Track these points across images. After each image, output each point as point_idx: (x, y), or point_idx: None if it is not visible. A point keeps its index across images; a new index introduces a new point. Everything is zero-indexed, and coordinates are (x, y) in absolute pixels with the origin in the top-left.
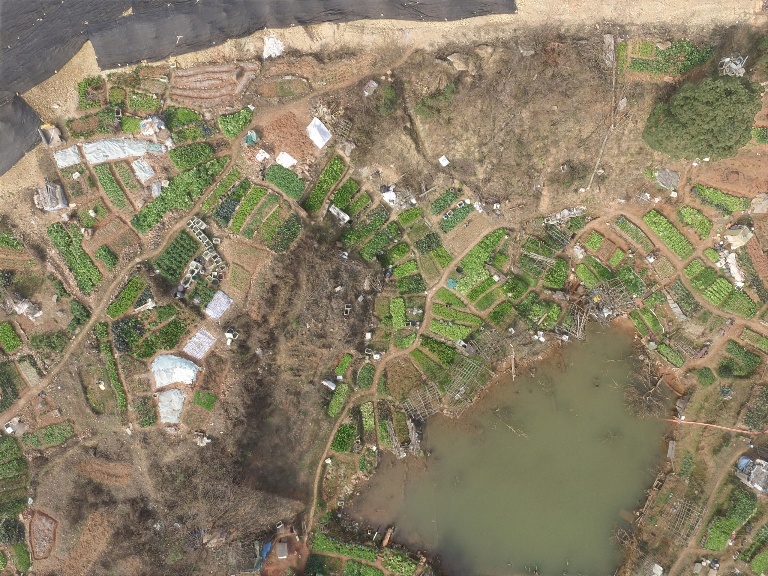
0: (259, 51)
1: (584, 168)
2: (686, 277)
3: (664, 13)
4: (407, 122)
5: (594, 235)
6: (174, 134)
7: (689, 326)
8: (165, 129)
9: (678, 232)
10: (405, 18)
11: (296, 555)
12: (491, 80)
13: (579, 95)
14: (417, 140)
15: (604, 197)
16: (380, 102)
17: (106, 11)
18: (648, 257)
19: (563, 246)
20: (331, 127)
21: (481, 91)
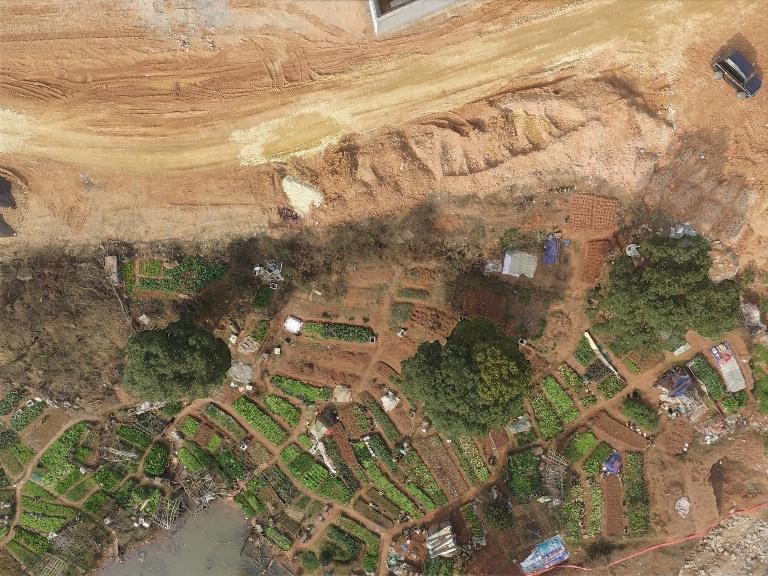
0: None
1: None
2: (283, 462)
3: (174, 230)
4: None
5: (189, 421)
6: None
7: (289, 512)
8: None
9: (269, 419)
10: None
11: None
12: None
13: (96, 313)
14: None
15: None
16: None
17: None
18: (238, 445)
19: (159, 432)
20: None
21: None
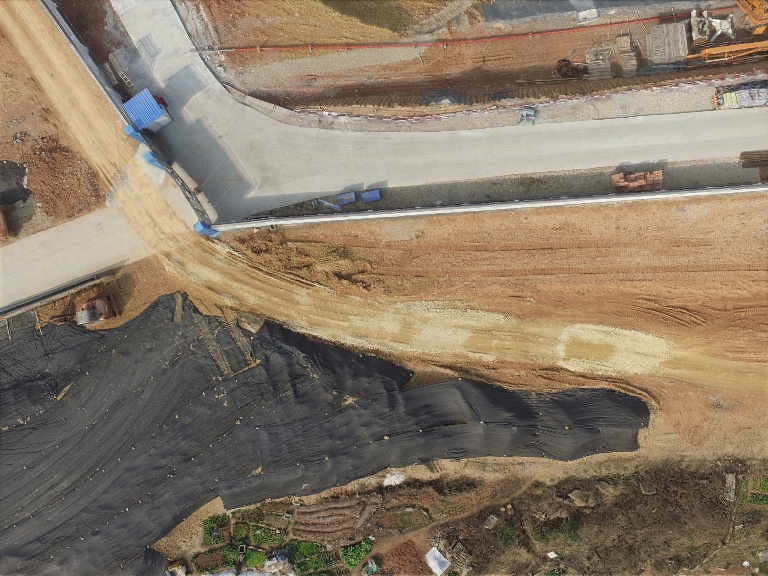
0: (380, 482)
1: (691, 561)
2: None
3: None
4: (522, 537)
5: None
6: (297, 568)
7: None
8: (288, 564)
9: None
10: (527, 455)
11: None
12: (609, 510)
13: (696, 521)
14: (528, 540)
15: (705, 569)
16: (498, 527)
17: (236, 469)
18: None
19: None
20: (451, 559)
21: (599, 518)
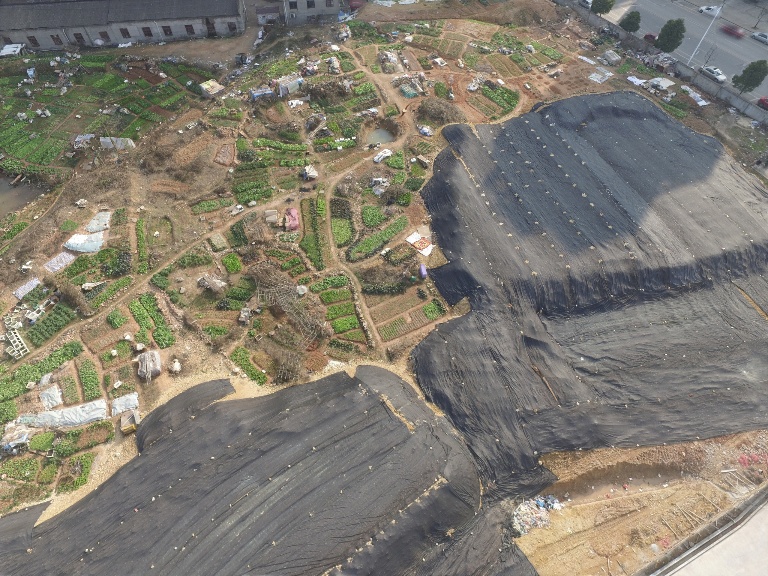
0: None
1: None
2: None
3: None
4: None
5: None
6: None
7: None
8: None
9: None
10: None
11: (81, 165)
12: None
13: None
14: None
15: None
16: None
17: None
18: None
19: None
20: None
21: None
